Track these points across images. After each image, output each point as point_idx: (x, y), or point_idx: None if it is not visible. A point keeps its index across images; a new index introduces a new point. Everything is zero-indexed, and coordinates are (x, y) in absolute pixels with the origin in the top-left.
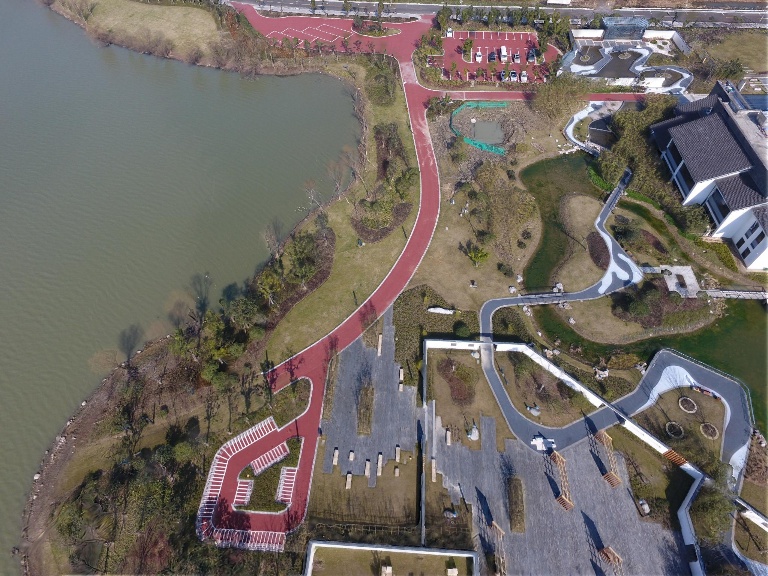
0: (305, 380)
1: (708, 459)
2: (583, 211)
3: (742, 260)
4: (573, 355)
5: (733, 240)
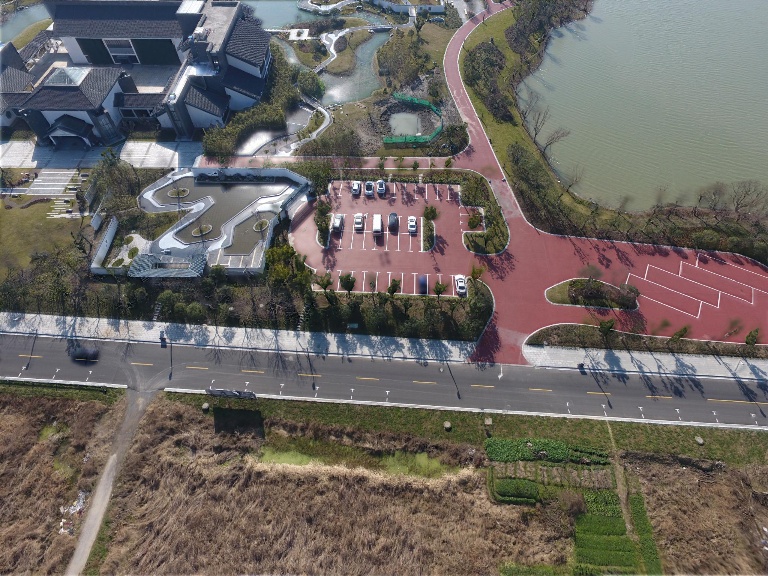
0: (497, 3)
1: None
2: (342, 62)
3: None
4: (371, 14)
5: None
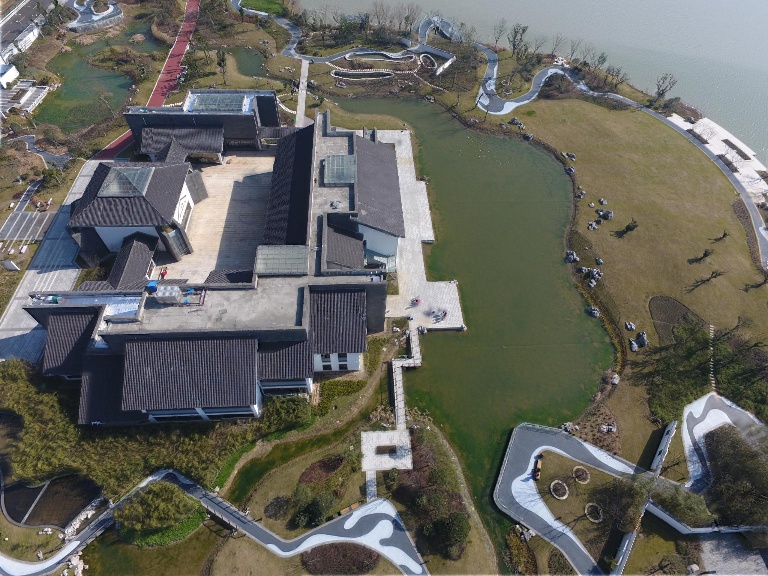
0: None
1: (635, 495)
2: (254, 575)
3: (348, 372)
4: None
5: (317, 372)
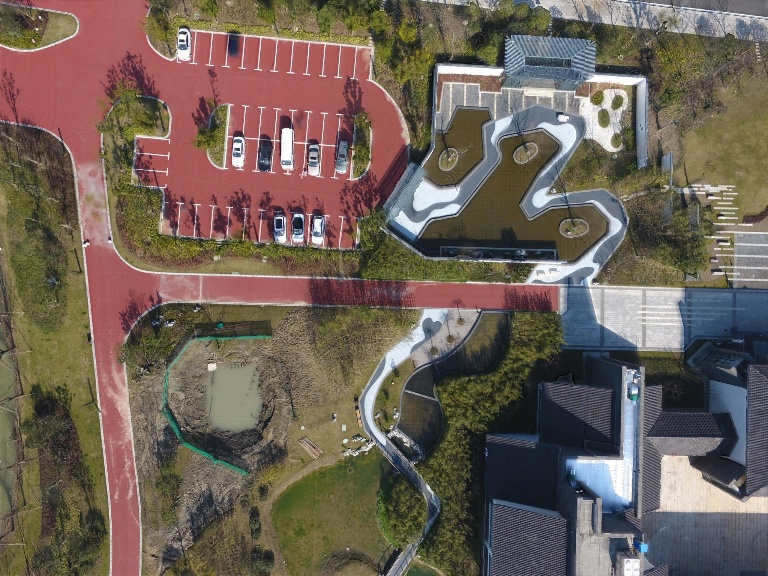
0: None
1: None
2: None
3: None
4: None
5: None
